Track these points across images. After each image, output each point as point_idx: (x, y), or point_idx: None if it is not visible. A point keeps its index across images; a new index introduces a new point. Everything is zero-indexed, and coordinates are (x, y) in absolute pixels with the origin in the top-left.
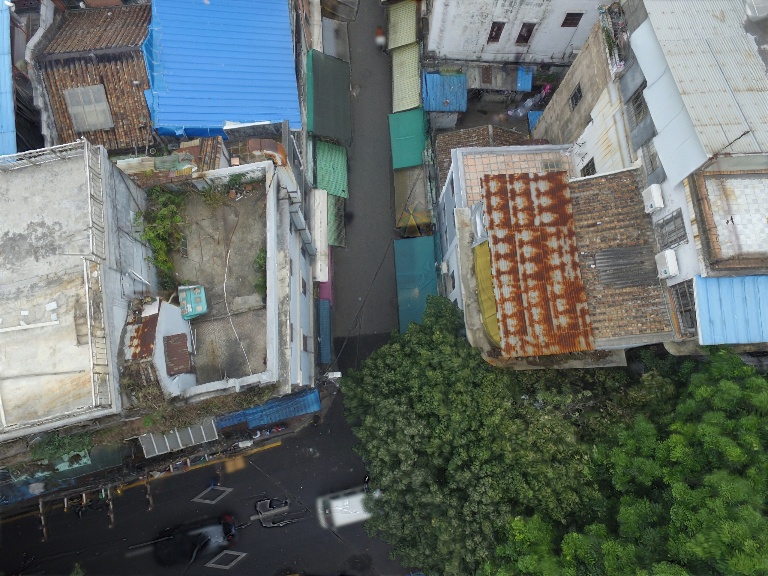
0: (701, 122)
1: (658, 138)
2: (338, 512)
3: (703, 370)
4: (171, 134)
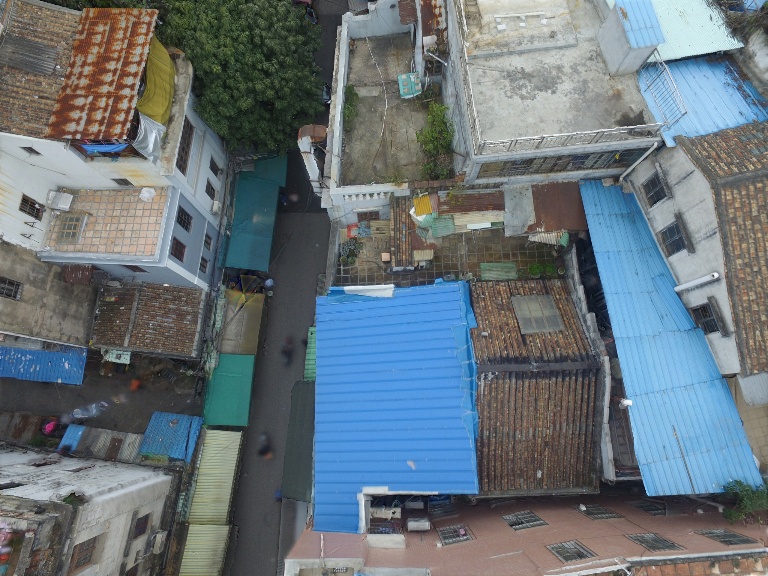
0: None
1: None
2: None
3: None
4: None
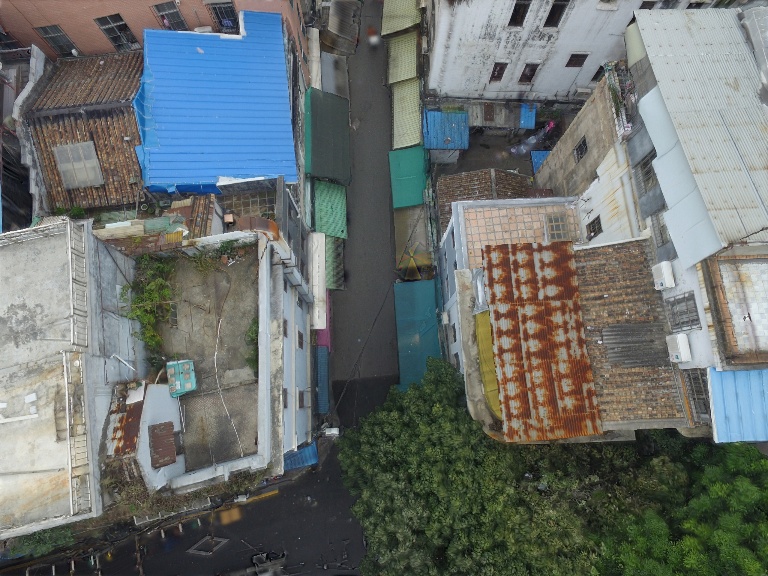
0: (715, 206)
1: (669, 214)
2: (336, 568)
3: (717, 457)
4: (163, 191)
